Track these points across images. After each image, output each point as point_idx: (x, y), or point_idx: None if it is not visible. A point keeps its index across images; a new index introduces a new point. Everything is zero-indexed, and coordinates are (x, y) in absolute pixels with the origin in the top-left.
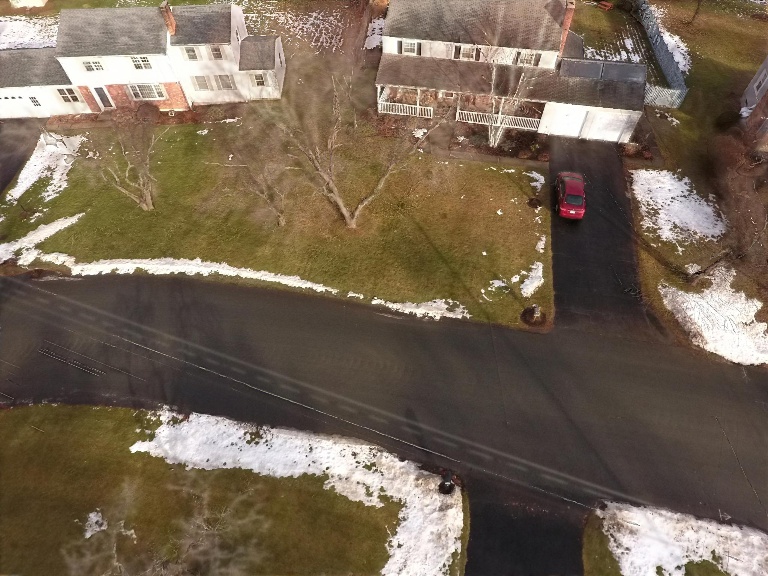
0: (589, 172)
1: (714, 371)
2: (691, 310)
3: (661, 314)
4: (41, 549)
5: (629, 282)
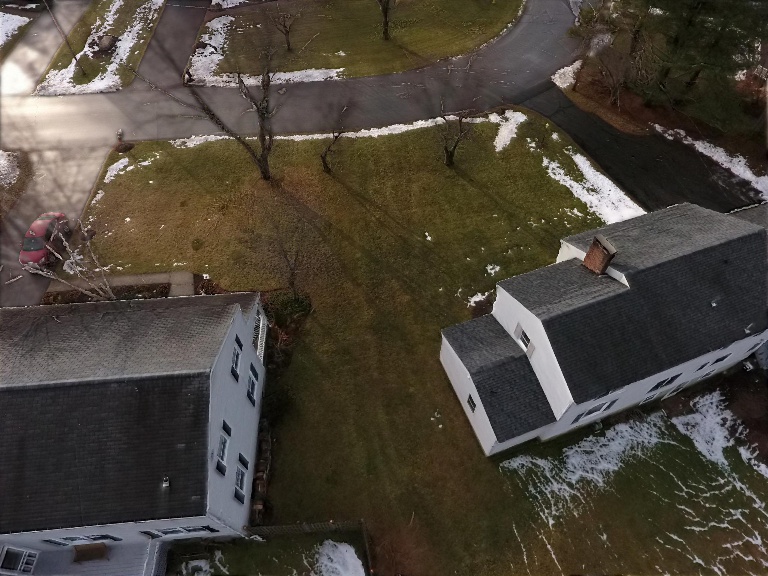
0: (2, 290)
1: (16, 143)
2: (3, 166)
3: (27, 165)
4: (355, 46)
5: (37, 182)
